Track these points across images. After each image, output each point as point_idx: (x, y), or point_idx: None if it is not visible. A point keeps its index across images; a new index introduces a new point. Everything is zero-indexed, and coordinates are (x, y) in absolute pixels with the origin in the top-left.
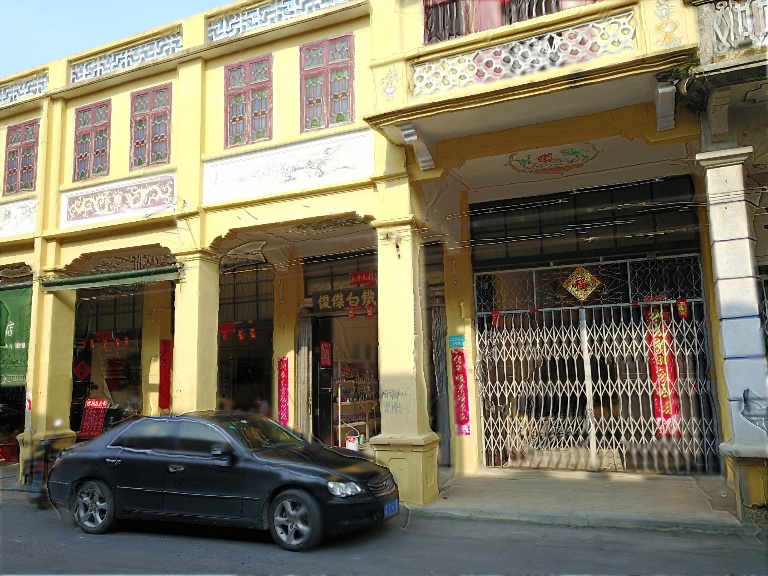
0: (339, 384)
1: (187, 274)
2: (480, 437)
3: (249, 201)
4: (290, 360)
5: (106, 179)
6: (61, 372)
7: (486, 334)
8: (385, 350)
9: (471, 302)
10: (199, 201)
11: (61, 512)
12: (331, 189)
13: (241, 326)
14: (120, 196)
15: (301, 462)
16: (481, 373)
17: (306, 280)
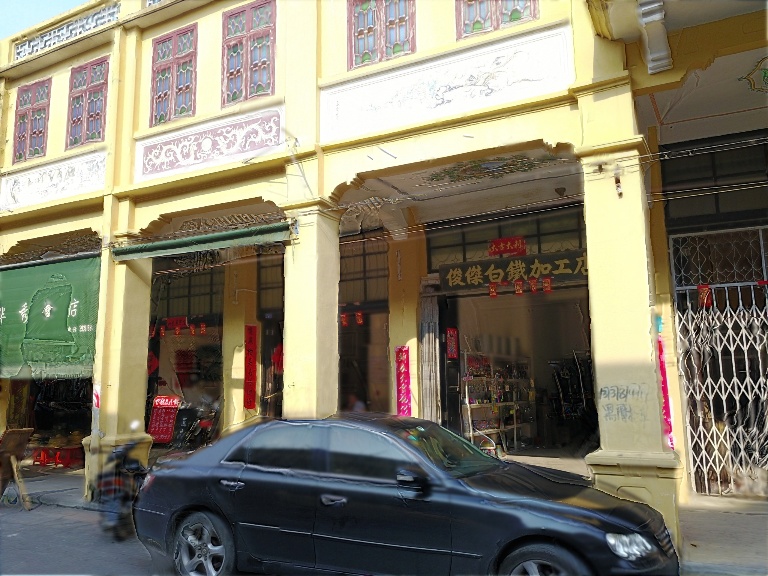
0: (466, 382)
1: (301, 233)
2: (687, 453)
3: (385, 134)
4: (411, 350)
5: (192, 120)
6: (135, 361)
7: (690, 315)
8: (603, 329)
9: (669, 273)
10: (316, 138)
11: (154, 554)
12: (506, 110)
13: (344, 309)
14: (209, 140)
15: (527, 494)
16: (690, 367)
17: (430, 251)
